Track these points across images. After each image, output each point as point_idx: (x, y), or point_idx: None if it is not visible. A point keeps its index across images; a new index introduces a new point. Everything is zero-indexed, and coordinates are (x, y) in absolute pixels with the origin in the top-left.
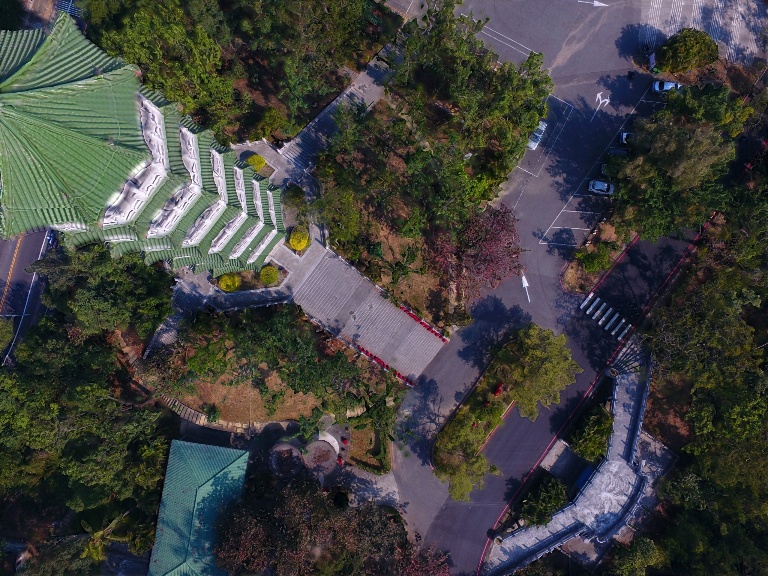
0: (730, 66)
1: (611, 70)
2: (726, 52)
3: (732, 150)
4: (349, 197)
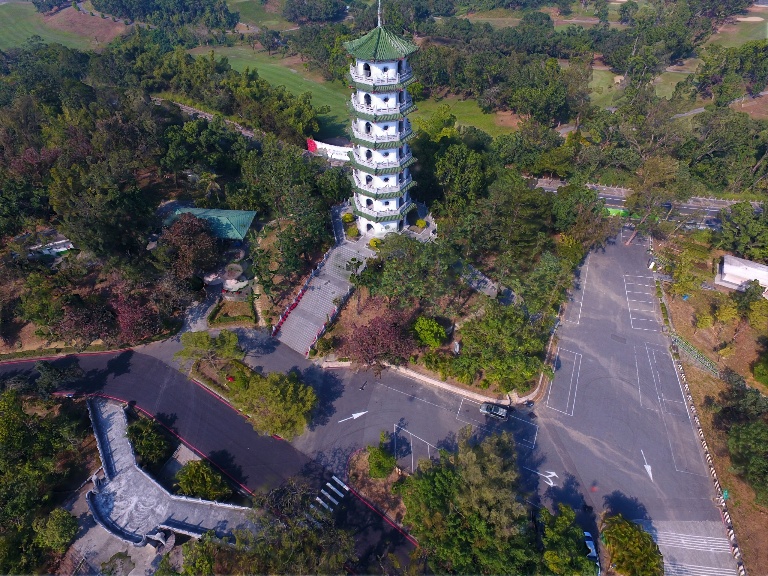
0: None
1: (586, 487)
2: None
3: None
4: None
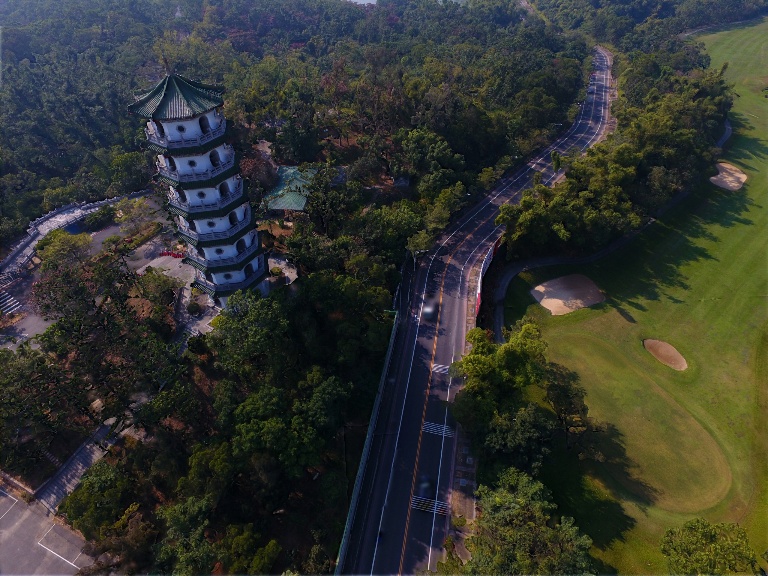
0: None
1: None
2: None
3: None
4: None
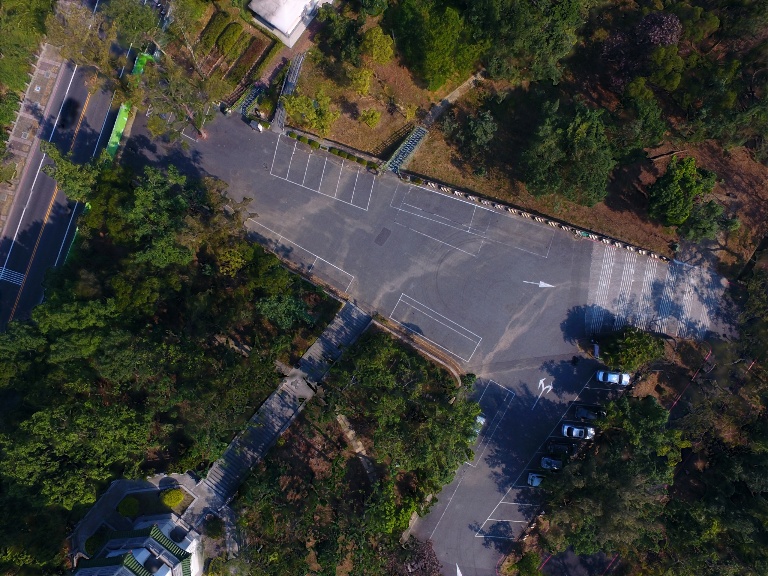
0: (681, 341)
1: (555, 355)
2: (677, 327)
3: (670, 476)
4: (271, 527)
